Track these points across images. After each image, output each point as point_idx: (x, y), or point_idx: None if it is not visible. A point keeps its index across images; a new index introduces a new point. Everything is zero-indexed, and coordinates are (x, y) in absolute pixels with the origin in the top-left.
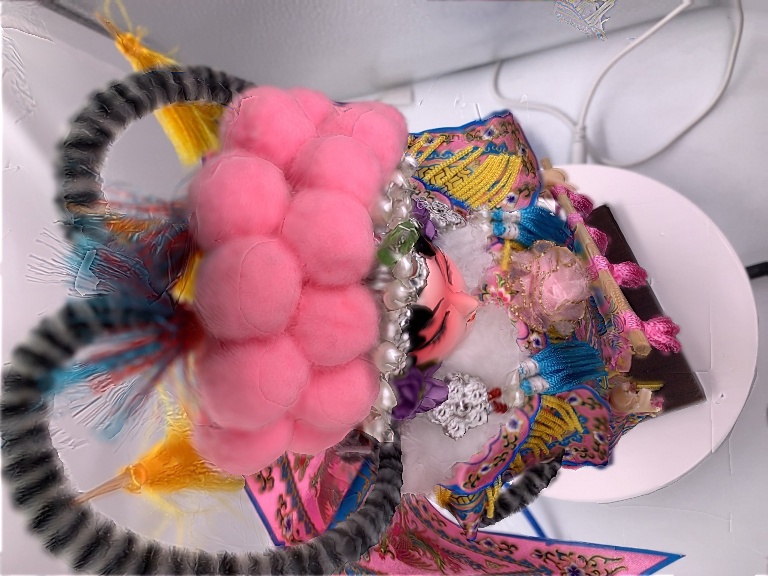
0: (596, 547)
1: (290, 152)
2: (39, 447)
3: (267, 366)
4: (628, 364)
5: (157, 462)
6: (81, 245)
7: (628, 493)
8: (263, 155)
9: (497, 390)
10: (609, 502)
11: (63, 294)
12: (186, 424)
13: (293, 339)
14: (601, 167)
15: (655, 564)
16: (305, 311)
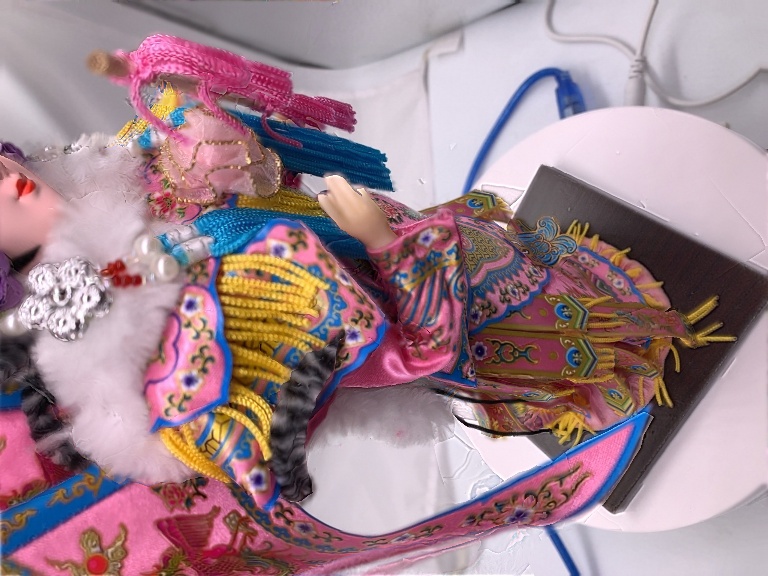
0: (544, 471)
1: None
2: None
3: None
4: (664, 299)
5: None
6: None
7: None
8: None
9: (117, 263)
10: None
11: None
12: None
13: None
14: (524, 139)
15: (625, 447)
16: None
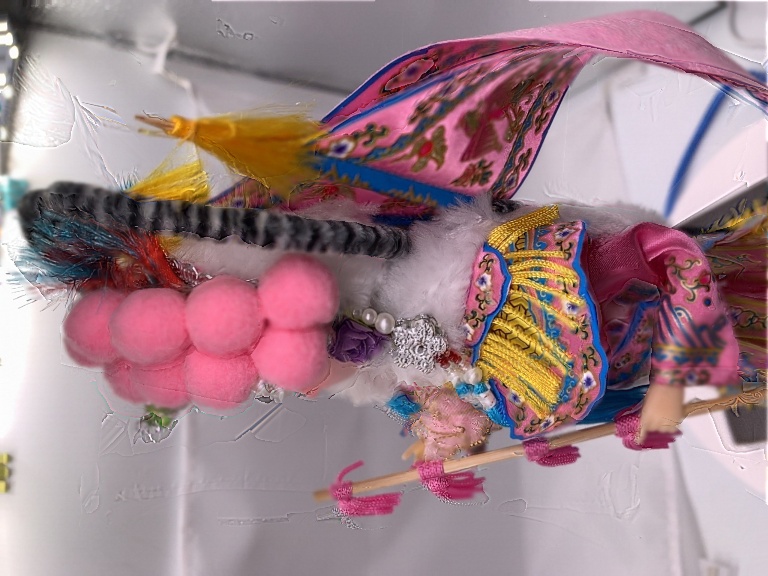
0: None
1: None
2: None
3: None
4: None
5: None
6: None
7: None
8: None
9: None
10: None
11: None
12: None
13: None
14: None
15: None
16: None
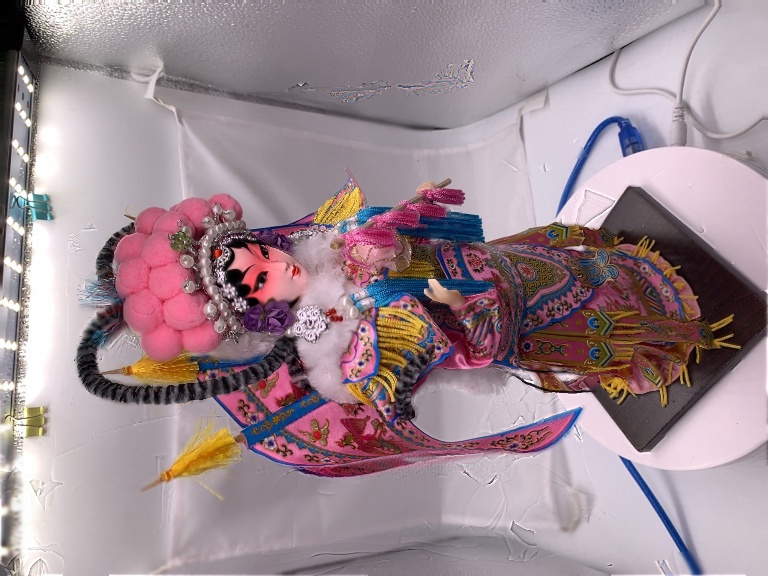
0: (532, 425)
1: (151, 227)
2: (88, 360)
3: (135, 300)
4: (697, 309)
5: (137, 365)
6: (89, 285)
7: (760, 436)
8: (143, 232)
9: (333, 310)
10: (749, 452)
11: (95, 308)
12: (137, 343)
13: (149, 290)
14: (622, 159)
15: (569, 421)
16: (150, 278)
